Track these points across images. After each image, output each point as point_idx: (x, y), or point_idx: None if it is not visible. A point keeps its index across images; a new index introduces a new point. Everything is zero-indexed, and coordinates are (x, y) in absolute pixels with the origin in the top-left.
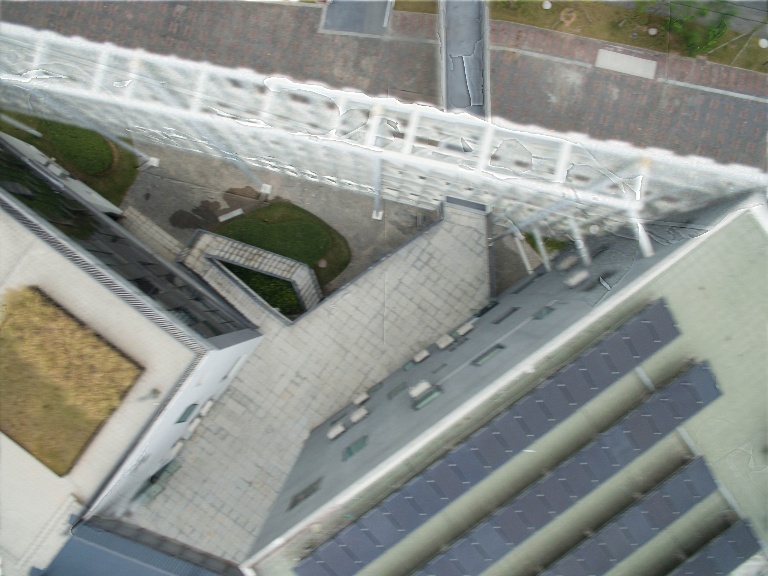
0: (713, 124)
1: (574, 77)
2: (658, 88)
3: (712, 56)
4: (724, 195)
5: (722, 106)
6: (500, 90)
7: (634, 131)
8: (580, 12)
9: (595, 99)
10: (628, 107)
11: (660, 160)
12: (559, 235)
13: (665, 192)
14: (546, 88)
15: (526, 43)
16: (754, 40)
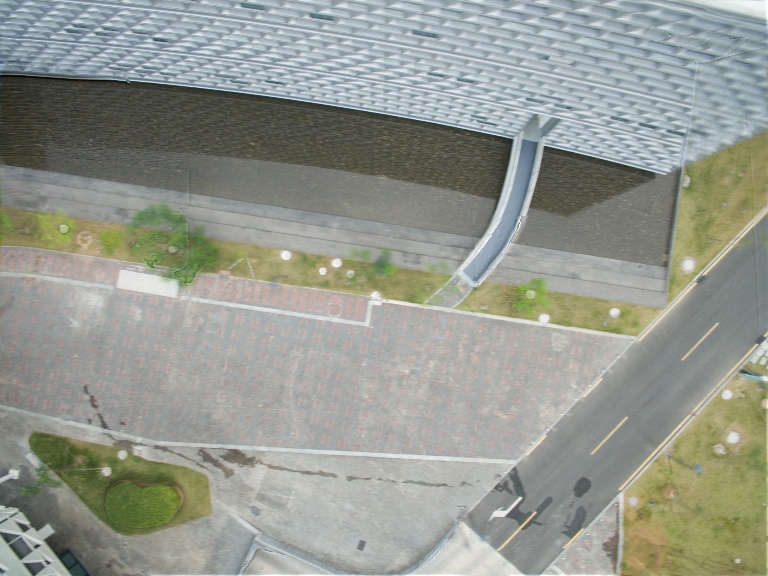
0: (239, 341)
1: (96, 300)
2: (182, 307)
3: (235, 271)
4: (254, 413)
5: (247, 322)
6: (21, 318)
7: (159, 352)
8: (96, 235)
9: (118, 321)
10: (152, 328)
11: (187, 380)
12: (83, 464)
13: (193, 413)
14: (68, 313)
15: (46, 268)
16: (276, 253)
